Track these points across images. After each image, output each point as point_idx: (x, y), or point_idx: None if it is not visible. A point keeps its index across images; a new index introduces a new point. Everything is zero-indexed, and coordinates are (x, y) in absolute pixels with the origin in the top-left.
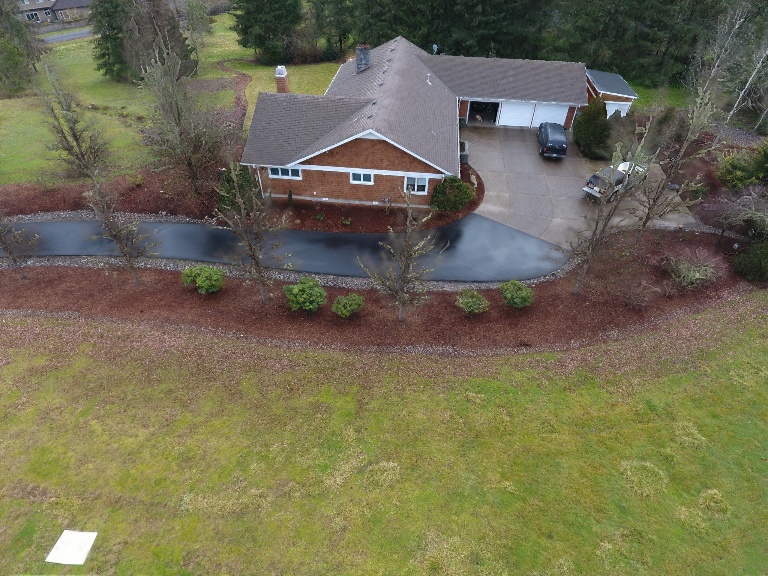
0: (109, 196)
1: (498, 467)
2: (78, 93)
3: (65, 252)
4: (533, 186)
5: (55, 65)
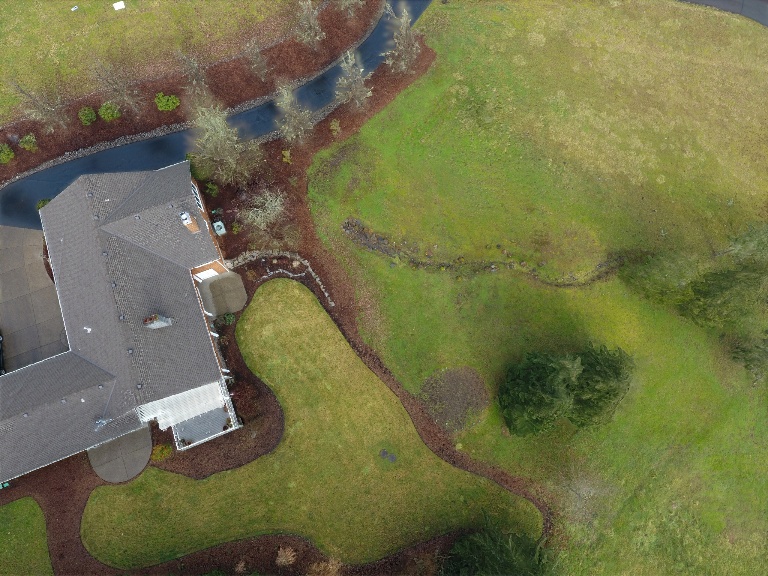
0: (194, 70)
1: (3, 71)
2: (548, 290)
3: (273, 102)
4: (7, 284)
5: (766, 402)
